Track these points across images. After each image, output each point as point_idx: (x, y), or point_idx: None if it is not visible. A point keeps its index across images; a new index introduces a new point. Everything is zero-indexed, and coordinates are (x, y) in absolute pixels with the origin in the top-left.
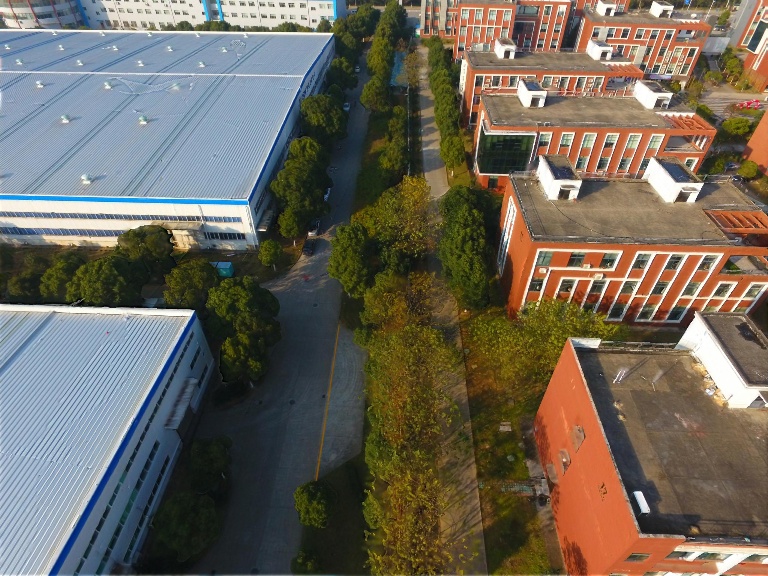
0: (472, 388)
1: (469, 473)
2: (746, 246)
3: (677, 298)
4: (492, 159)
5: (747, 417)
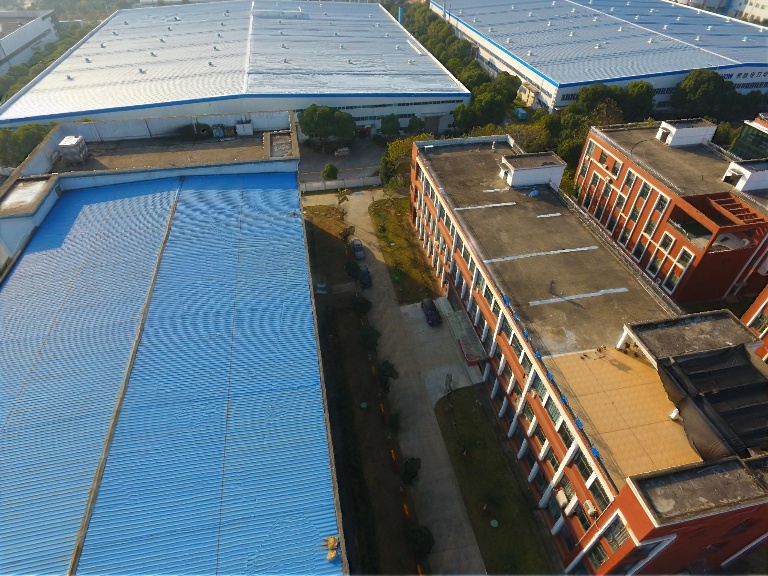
0: None
1: None
2: None
3: (641, 232)
4: (740, 150)
5: (497, 179)
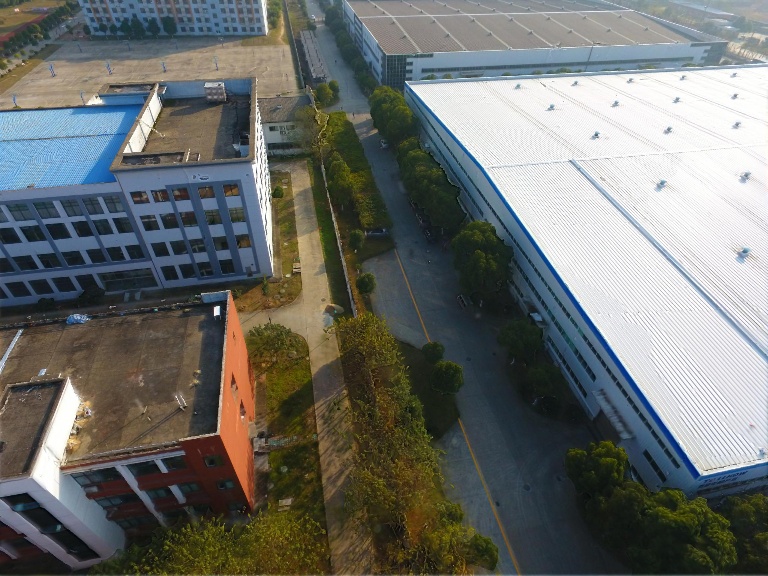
0: None
1: (326, 444)
2: None
3: None
4: None
5: None
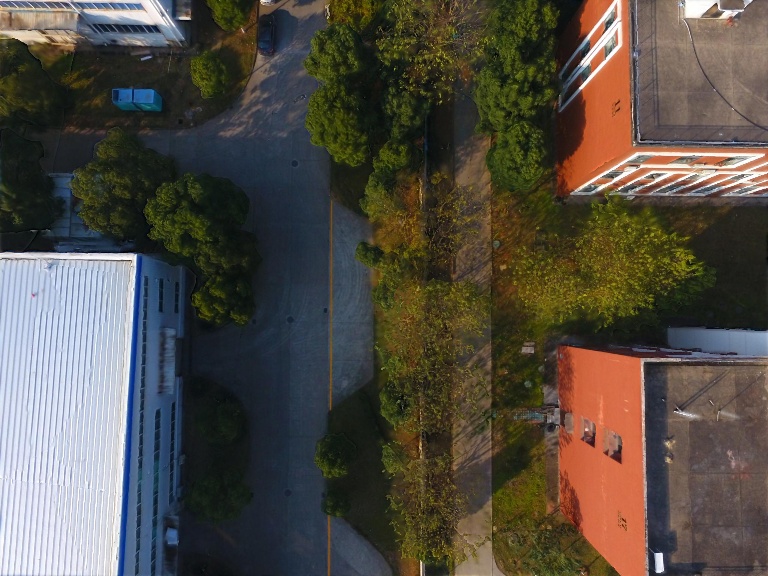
0: (497, 299)
1: (484, 403)
2: None
3: None
4: None
5: None
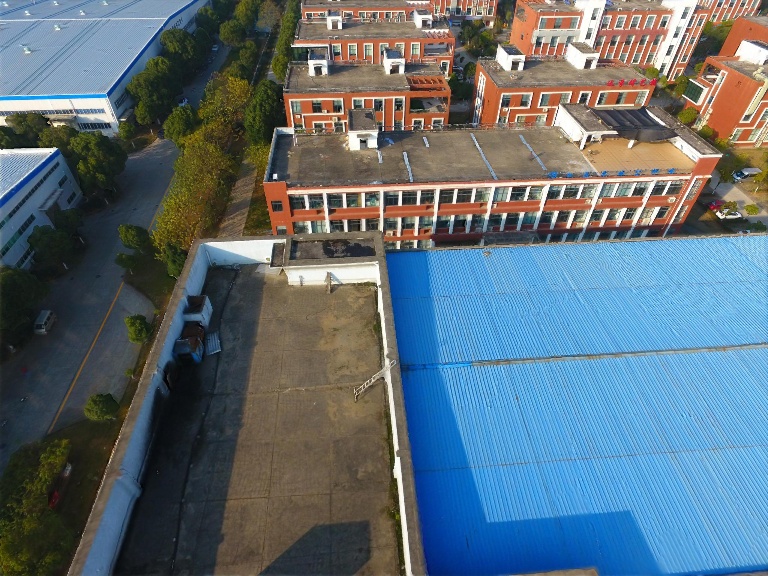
0: (256, 194)
1: (239, 227)
2: (417, 91)
3: None
4: None
5: (357, 153)
